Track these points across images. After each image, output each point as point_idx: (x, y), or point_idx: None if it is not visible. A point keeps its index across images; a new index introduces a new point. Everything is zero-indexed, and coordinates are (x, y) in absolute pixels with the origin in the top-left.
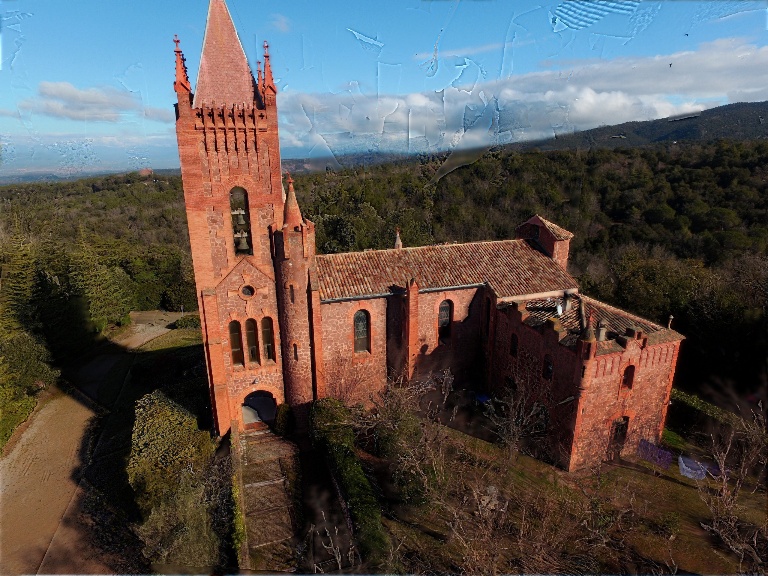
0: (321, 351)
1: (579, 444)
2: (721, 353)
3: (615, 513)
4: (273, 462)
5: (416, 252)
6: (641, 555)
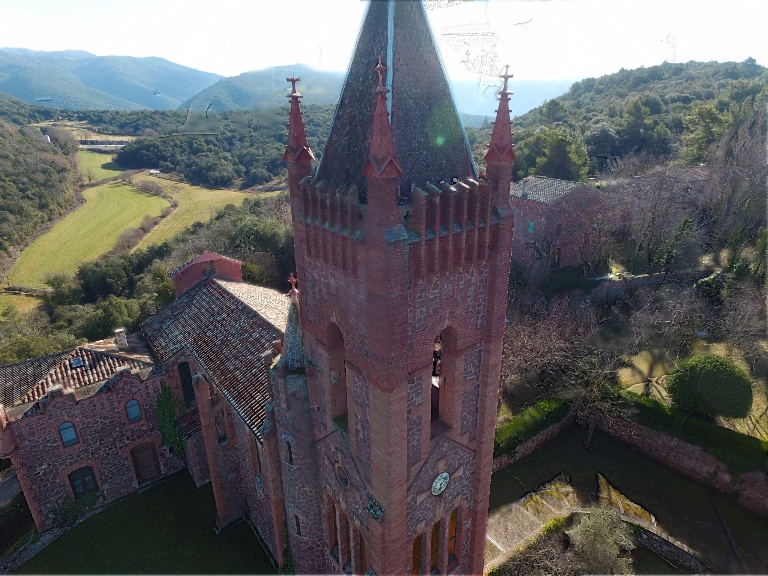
0: None
1: None
2: None
3: None
4: None
5: None
6: None
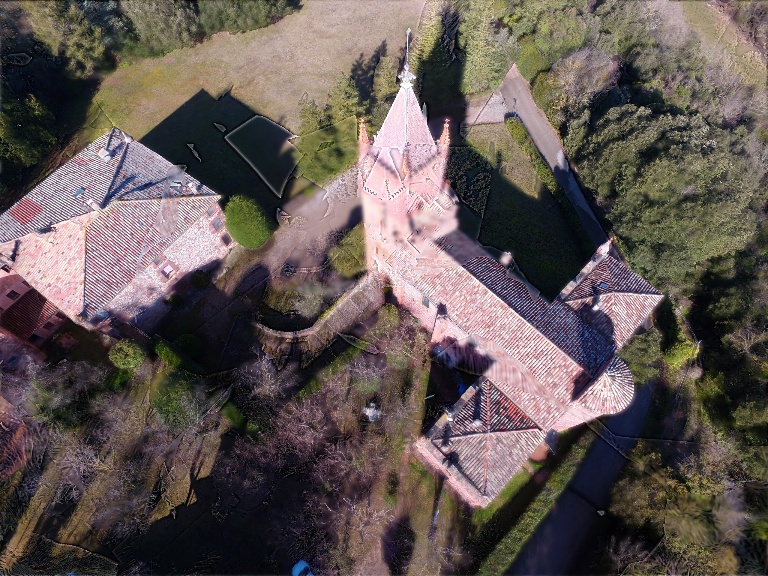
0: (401, 290)
1: (422, 451)
2: (604, 569)
3: (394, 474)
4: (369, 301)
5: (492, 299)
6: (372, 485)
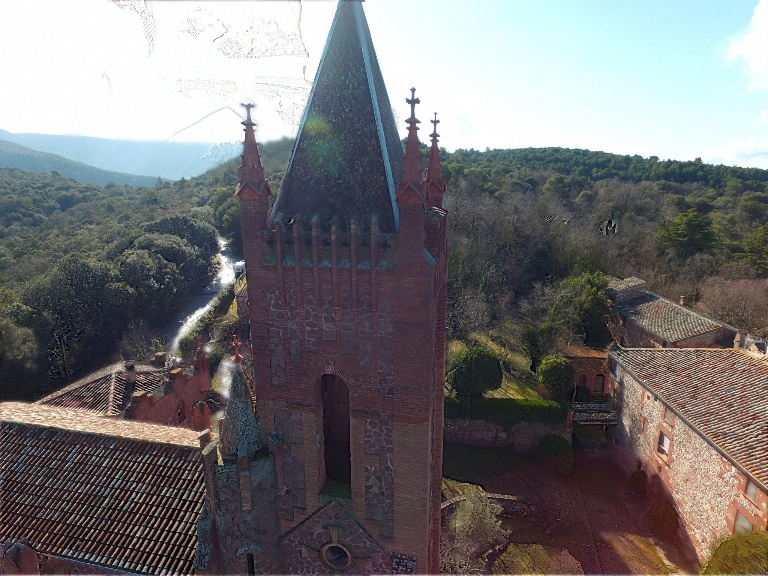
0: None
1: None
2: None
3: None
4: None
5: None
6: None
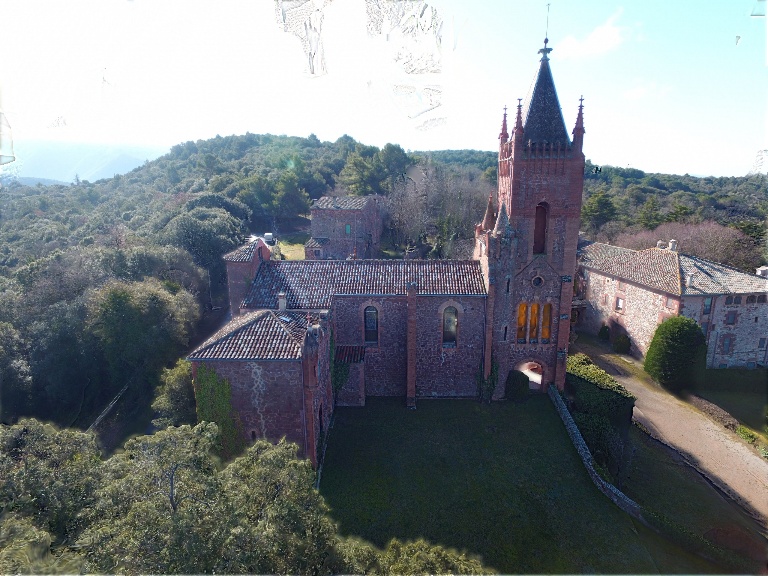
0: None
1: None
2: None
3: None
4: None
5: None
6: None
